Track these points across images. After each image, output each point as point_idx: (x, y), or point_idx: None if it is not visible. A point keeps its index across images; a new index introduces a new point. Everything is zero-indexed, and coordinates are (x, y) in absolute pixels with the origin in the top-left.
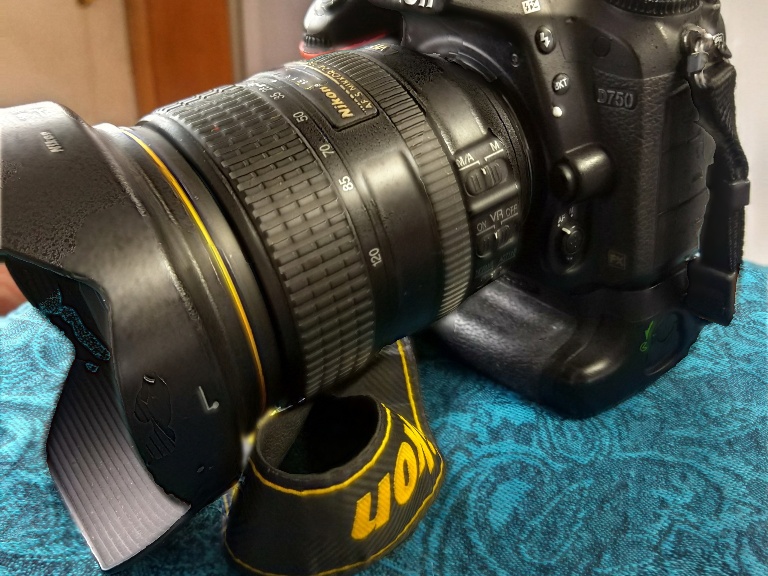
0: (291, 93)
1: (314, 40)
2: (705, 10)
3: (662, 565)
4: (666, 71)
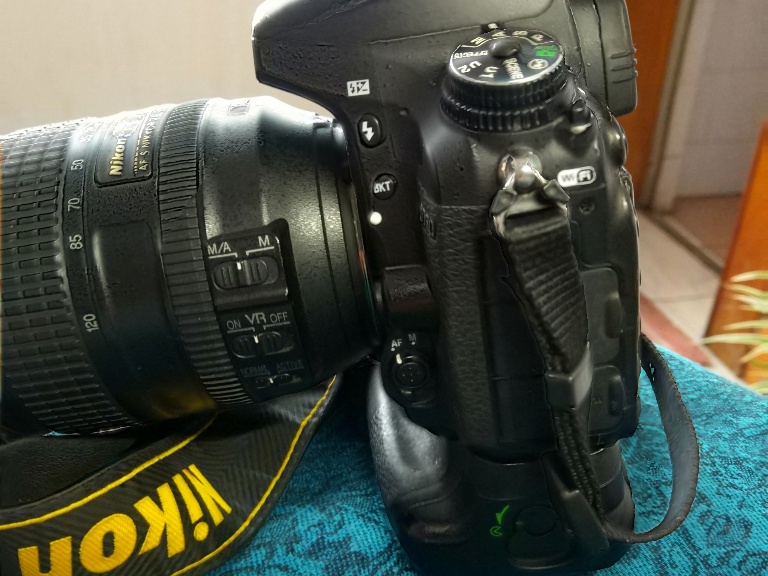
0: (98, 138)
1: None
2: (562, 131)
3: None
4: (476, 202)
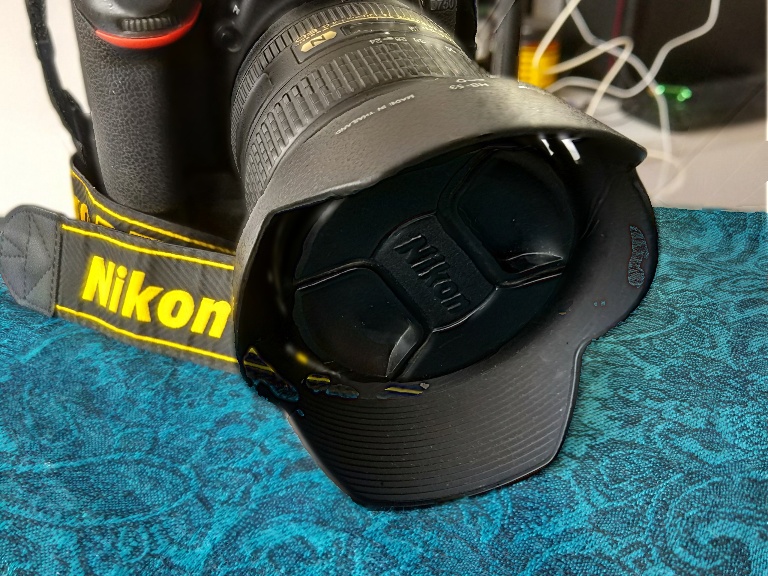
0: (418, 36)
1: (160, 21)
2: None
3: None
4: None
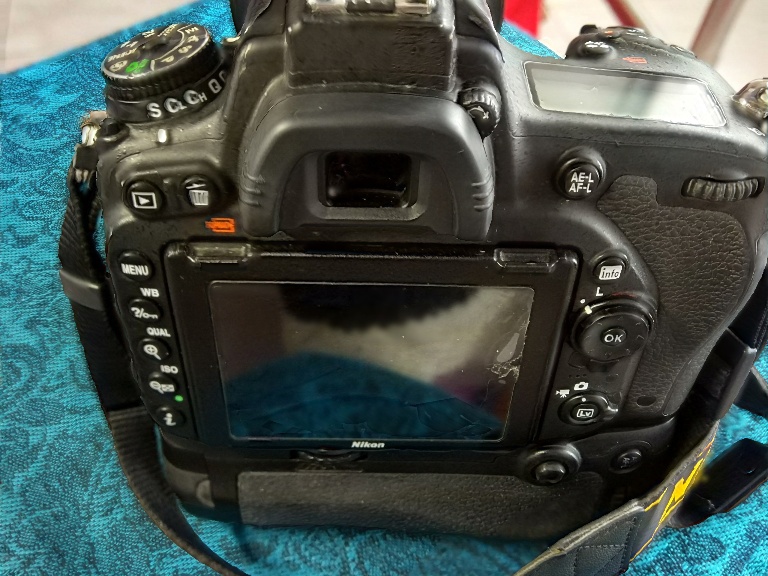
0: None
1: None
2: None
3: None
4: None
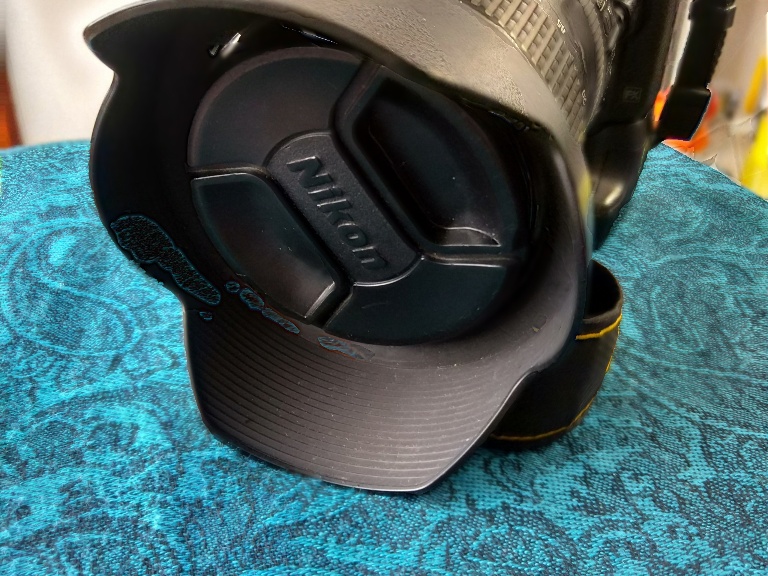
0: None
1: None
2: None
3: (760, 324)
4: None
